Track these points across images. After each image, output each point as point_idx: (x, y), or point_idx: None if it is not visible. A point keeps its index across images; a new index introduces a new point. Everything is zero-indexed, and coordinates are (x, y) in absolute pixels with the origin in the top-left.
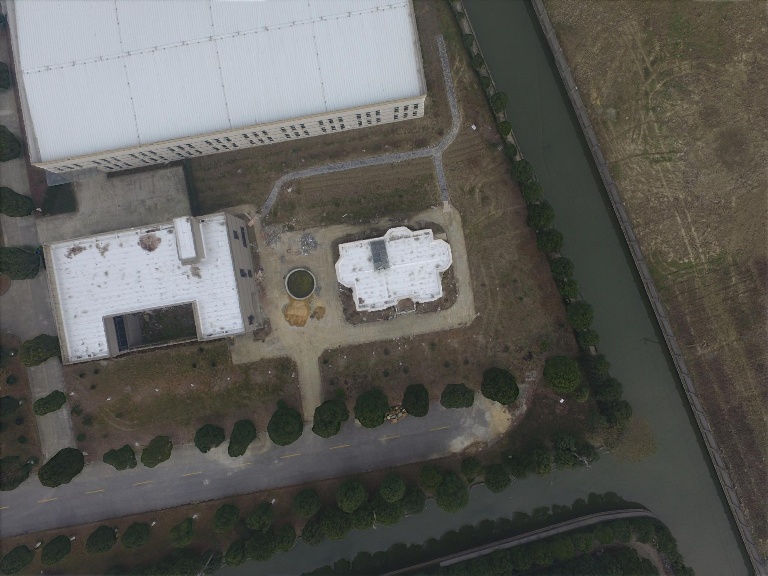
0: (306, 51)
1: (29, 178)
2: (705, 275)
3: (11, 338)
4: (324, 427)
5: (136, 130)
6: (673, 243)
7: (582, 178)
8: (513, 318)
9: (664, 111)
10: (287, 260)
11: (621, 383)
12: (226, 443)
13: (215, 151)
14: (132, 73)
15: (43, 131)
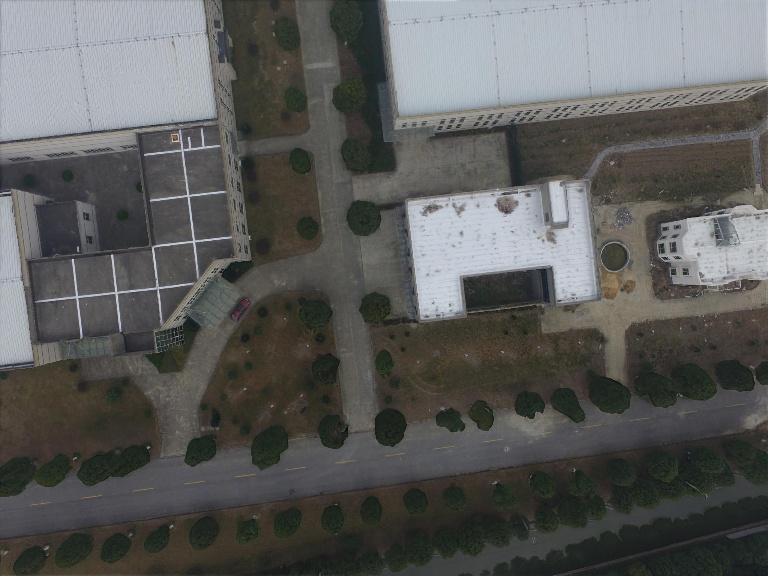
0: (672, 25)
1: (348, 134)
2: None
3: (320, 296)
4: (670, 396)
5: (497, 91)
6: None
7: None
8: None
9: None
10: (602, 233)
11: None
12: None
13: (542, 119)
14: (499, 33)
15: (403, 85)
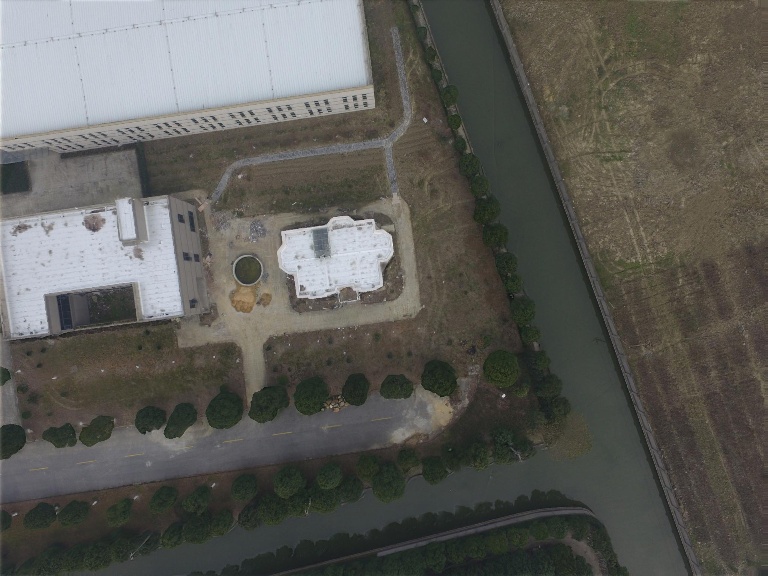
0: (255, 38)
1: None
2: (652, 275)
3: None
4: (259, 412)
5: (85, 111)
6: (621, 242)
7: (535, 175)
8: (458, 311)
9: (616, 110)
10: (236, 246)
11: (561, 380)
12: None
13: (167, 135)
14: (82, 54)
15: None
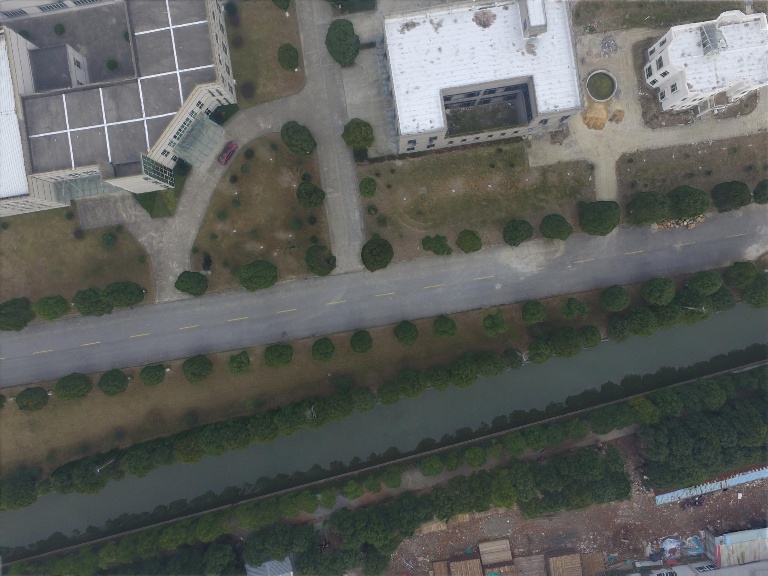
0: None
1: None
2: None
3: None
4: (661, 205)
5: None
6: None
7: None
8: None
9: None
10: (587, 62)
11: None
12: (520, 247)
13: None
14: None
15: None
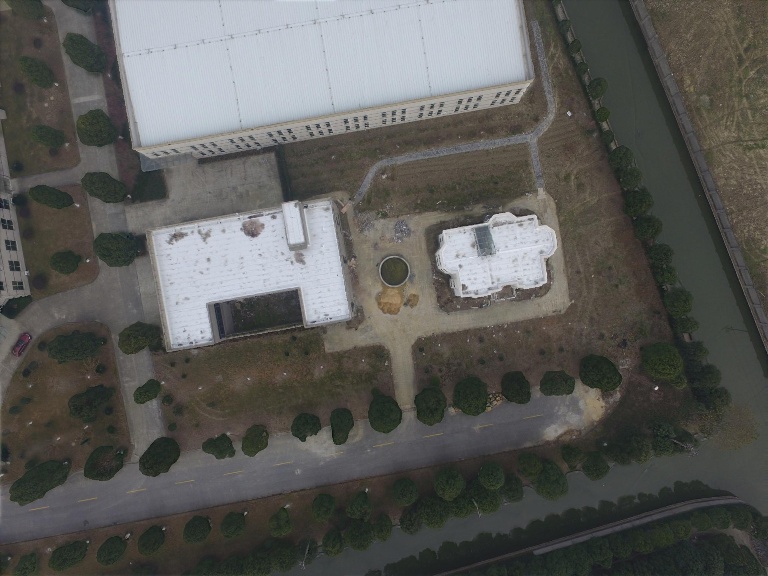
0: (411, 35)
1: (118, 164)
2: None
3: (100, 327)
4: (431, 414)
5: (238, 114)
6: (766, 230)
7: (671, 166)
8: (608, 305)
9: (757, 98)
10: (380, 247)
11: (719, 370)
12: (318, 432)
13: (309, 137)
14: (235, 56)
15: (143, 115)
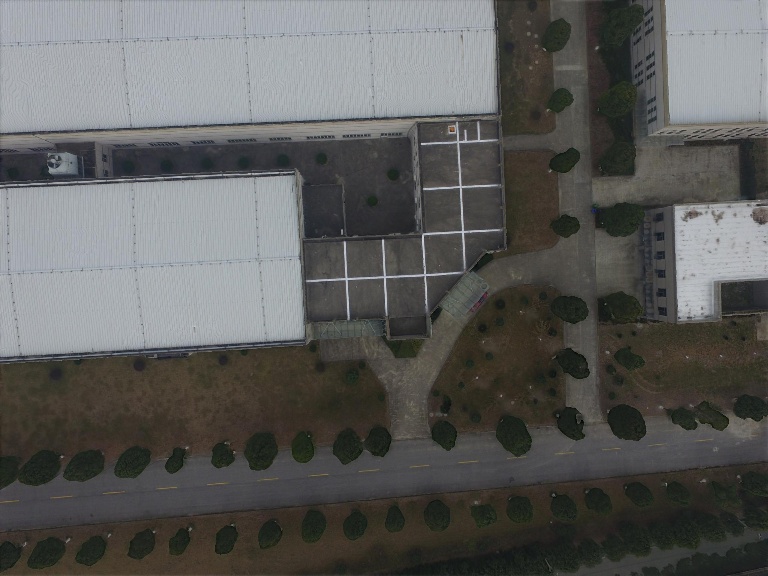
0: None
1: (592, 136)
2: None
3: (554, 291)
4: None
5: (759, 106)
6: None
7: None
8: None
9: None
10: None
11: None
12: None
13: None
14: (767, 50)
15: (673, 94)
